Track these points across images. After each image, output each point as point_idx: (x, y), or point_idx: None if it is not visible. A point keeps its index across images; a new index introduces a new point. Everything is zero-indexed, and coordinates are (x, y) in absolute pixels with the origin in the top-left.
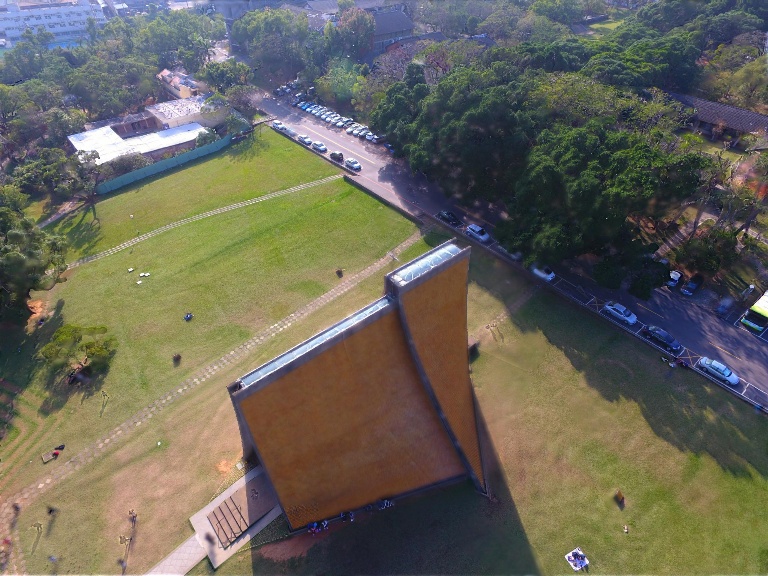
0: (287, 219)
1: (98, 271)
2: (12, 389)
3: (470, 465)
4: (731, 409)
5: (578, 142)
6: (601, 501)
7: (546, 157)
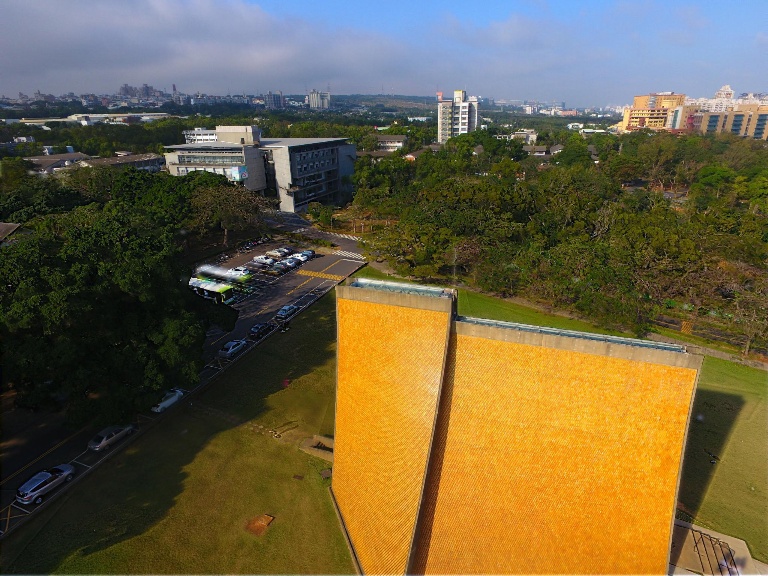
0: None
1: None
2: None
3: None
4: (318, 311)
5: (23, 265)
6: None
7: (35, 296)
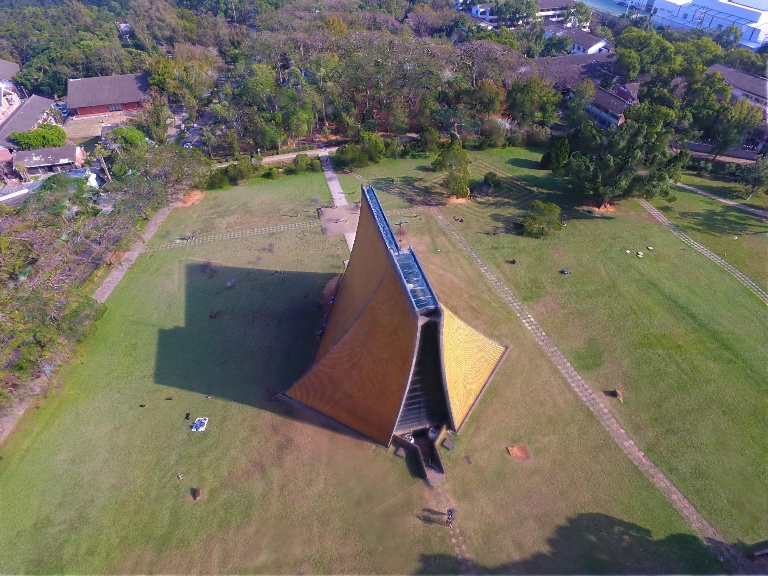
0: (760, 372)
1: (653, 233)
2: (520, 205)
3: (300, 379)
4: None
5: None
6: (210, 477)
7: None
